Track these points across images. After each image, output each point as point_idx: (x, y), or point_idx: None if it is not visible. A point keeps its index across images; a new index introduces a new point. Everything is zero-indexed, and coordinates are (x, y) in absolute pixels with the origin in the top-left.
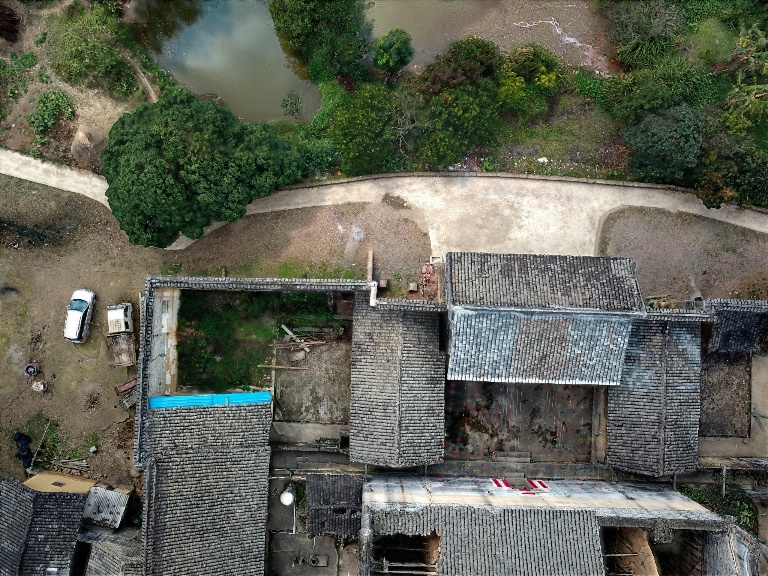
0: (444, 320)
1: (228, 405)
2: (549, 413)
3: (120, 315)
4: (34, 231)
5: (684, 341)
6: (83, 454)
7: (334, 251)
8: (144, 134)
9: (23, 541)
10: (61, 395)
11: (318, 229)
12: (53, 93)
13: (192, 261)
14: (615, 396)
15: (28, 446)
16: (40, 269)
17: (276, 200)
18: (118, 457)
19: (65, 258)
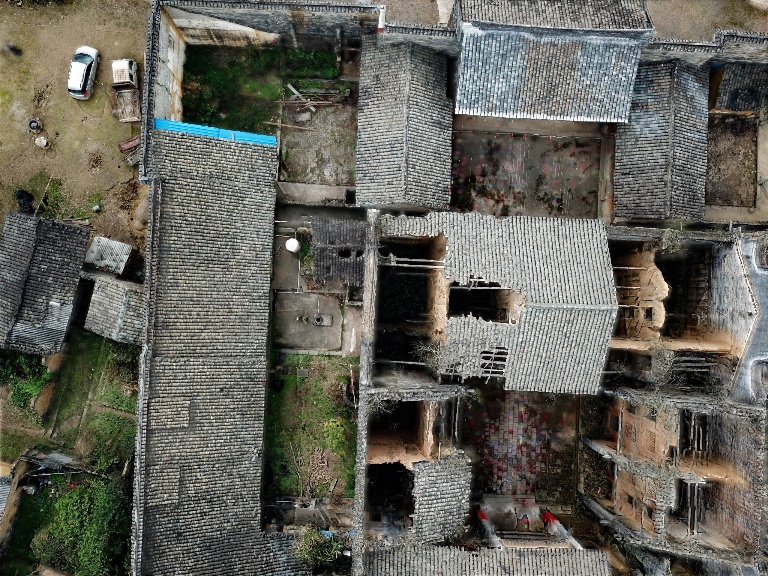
0: (452, 71)
1: (234, 141)
2: (555, 180)
3: (125, 65)
4: None
5: (692, 88)
6: (86, 214)
7: None
8: None
9: (26, 268)
10: (64, 154)
11: None
12: None
13: None
14: (622, 145)
15: (30, 204)
16: (44, 27)
17: None
18: (121, 217)
19: (69, 17)
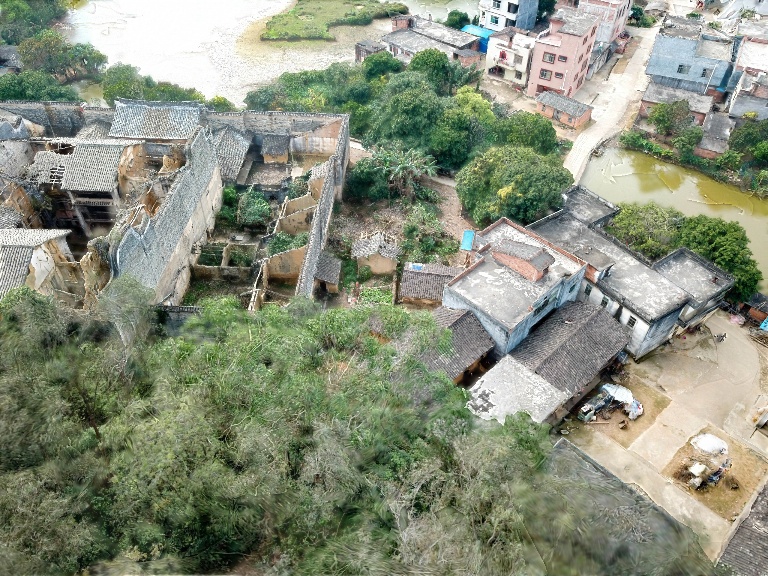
0: None
1: None
2: None
3: None
4: None
5: (239, 138)
6: None
7: None
8: None
9: None
10: None
11: None
12: None
13: None
14: None
15: None
16: None
17: None
18: None
19: None
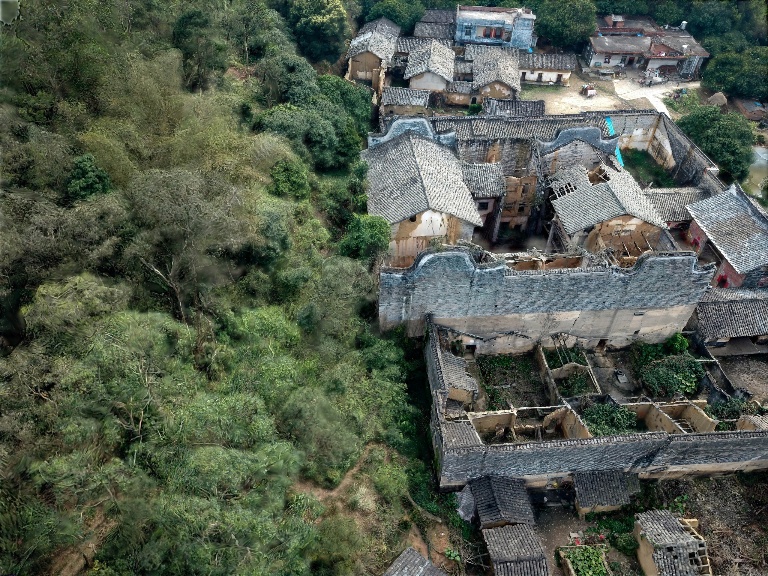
0: None
1: None
2: None
3: None
4: None
5: None
6: None
7: None
8: None
9: None
10: None
11: None
12: None
13: None
14: None
15: None
16: None
17: None
18: None
19: None
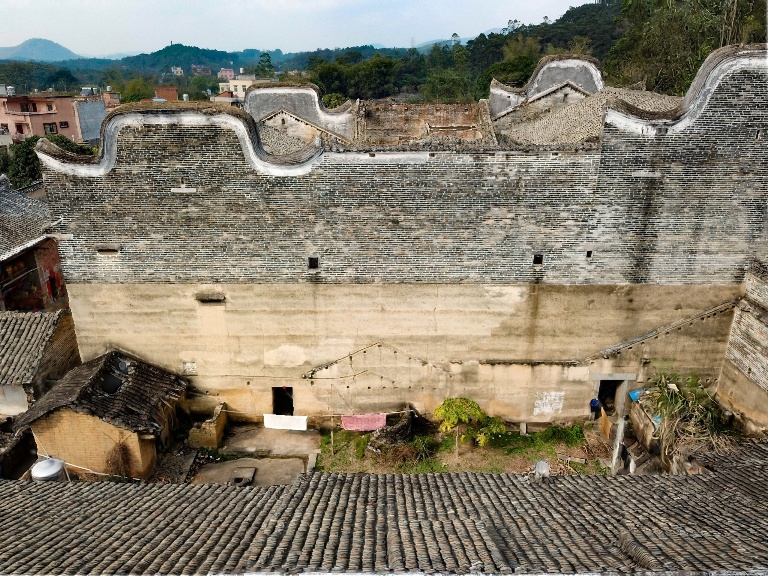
0: None
1: None
2: None
3: None
4: None
5: None
6: None
7: None
8: None
9: None
10: None
11: None
12: None
13: None
14: None
15: None
16: None
17: None
18: None
19: None
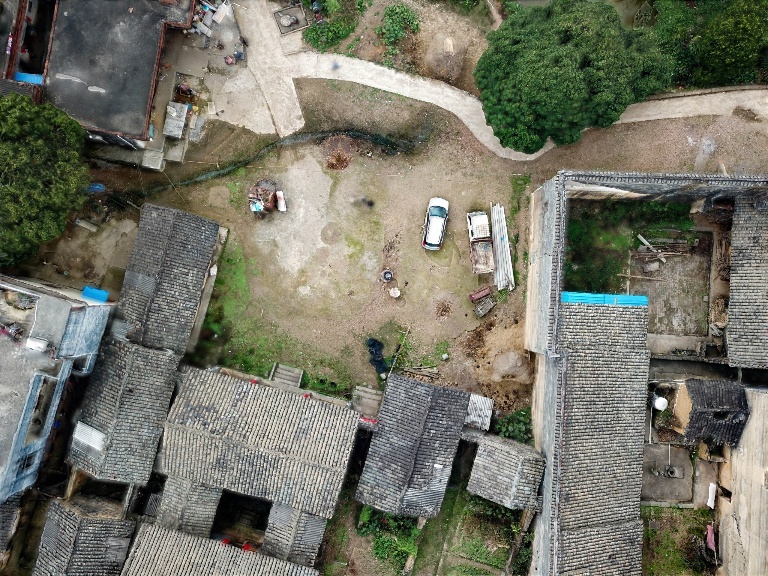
0: None
1: (616, 305)
2: None
3: (485, 220)
4: (387, 140)
5: None
6: (434, 361)
7: (684, 164)
8: (539, 33)
9: (419, 435)
10: (413, 302)
11: (668, 142)
12: (397, 6)
13: (541, 172)
14: None
15: (381, 352)
16: (393, 177)
17: (626, 112)
18: (468, 365)
19: (417, 167)
